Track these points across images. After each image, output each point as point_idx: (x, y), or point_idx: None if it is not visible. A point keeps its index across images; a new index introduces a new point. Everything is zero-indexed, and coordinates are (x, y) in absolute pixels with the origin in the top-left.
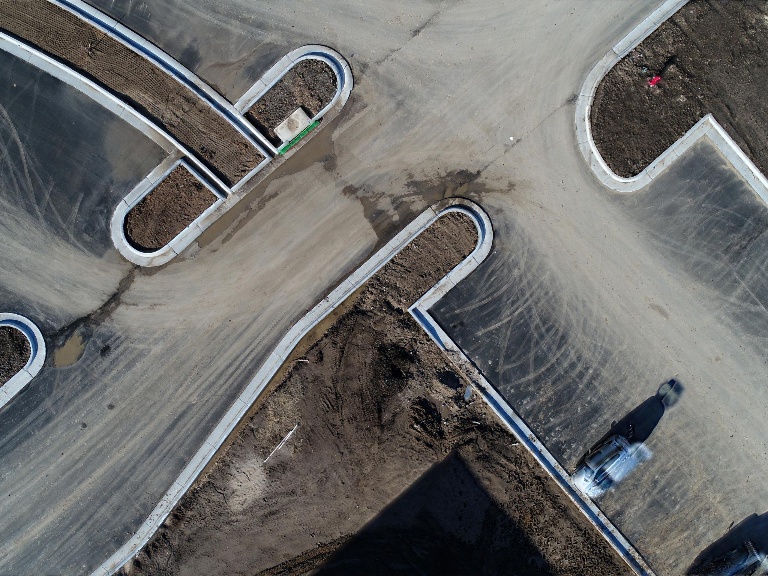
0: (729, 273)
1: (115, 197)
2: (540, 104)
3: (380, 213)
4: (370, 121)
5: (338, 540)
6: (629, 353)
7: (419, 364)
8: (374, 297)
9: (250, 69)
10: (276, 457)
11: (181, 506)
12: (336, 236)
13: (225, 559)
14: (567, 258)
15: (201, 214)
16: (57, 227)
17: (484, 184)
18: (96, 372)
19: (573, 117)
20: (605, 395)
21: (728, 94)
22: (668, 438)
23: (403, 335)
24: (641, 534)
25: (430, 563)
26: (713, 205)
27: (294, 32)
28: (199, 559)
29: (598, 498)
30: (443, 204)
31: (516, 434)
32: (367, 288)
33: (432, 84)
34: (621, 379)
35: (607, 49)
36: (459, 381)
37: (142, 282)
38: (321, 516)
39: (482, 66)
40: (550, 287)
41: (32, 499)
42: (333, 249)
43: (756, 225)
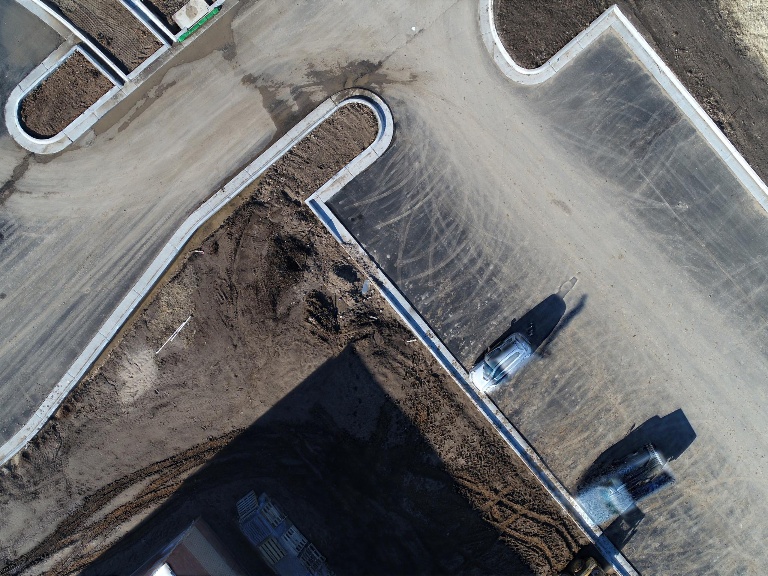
0: (633, 169)
1: (10, 82)
2: None
3: (279, 103)
4: (270, 9)
5: (230, 434)
6: (530, 250)
7: (316, 257)
8: (271, 188)
9: None
10: (168, 349)
11: (72, 397)
12: (234, 126)
13: (115, 451)
14: (469, 152)
15: (96, 101)
16: None
17: (385, 75)
18: None
19: (476, 7)
20: (505, 292)
21: None
22: (569, 337)
23: (300, 227)
24: (540, 434)
25: (324, 459)
26: (618, 99)
27: None
28: (89, 451)
29: (497, 397)
30: (343, 95)
31: (413, 329)
32: (264, 179)
33: None
34: (522, 276)
35: None
36: (357, 275)
37: (36, 169)
38: (213, 409)
39: None
40: (451, 181)
41: None
42: (231, 139)
43: (661, 120)
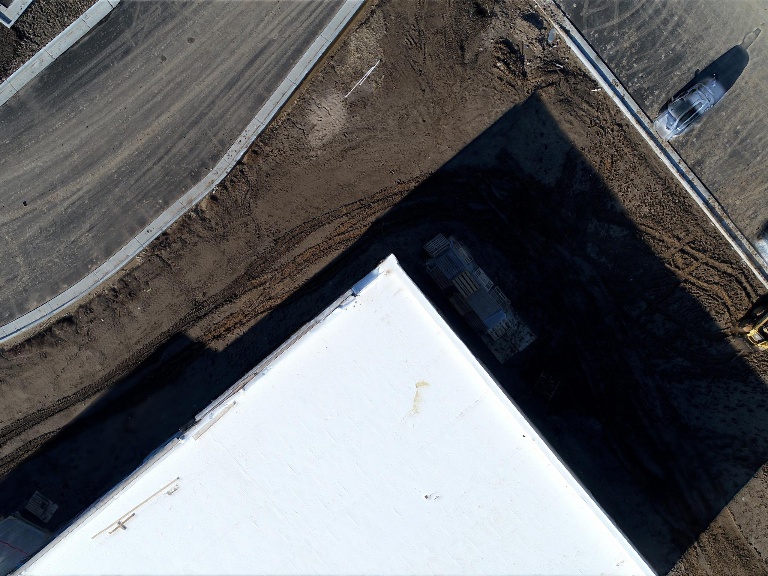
0: None
1: None
2: None
3: None
4: None
5: (418, 178)
6: (715, 0)
7: (503, 5)
8: None
9: None
10: (357, 93)
11: (260, 142)
12: None
13: (303, 194)
14: None
15: None
16: None
17: None
18: (177, 5)
19: None
20: (690, 43)
21: None
22: (752, 88)
23: None
24: (721, 184)
25: (509, 205)
26: None
27: None
28: (277, 194)
29: (679, 146)
30: None
31: (599, 77)
32: None
33: None
34: (706, 27)
35: None
36: (543, 24)
37: None
38: (401, 153)
39: None
40: None
41: (110, 132)
42: None
43: None
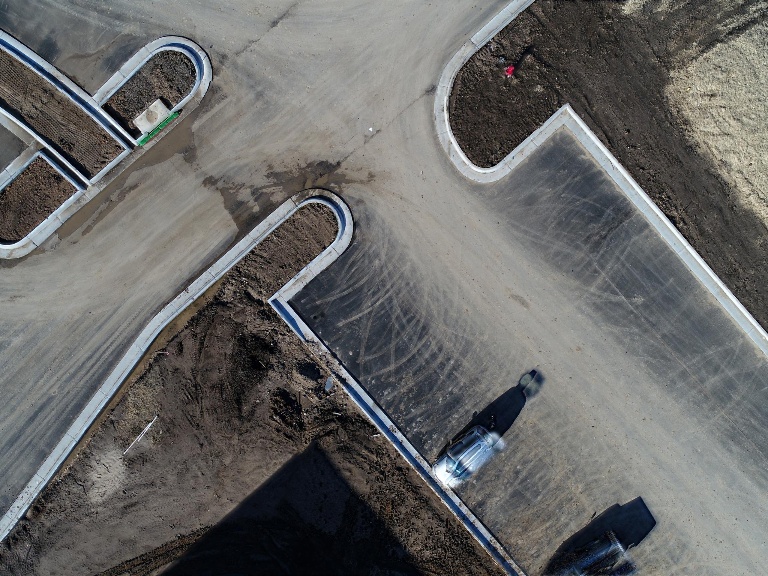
0: (589, 263)
1: None
2: (399, 95)
3: (240, 204)
4: (230, 112)
5: (198, 532)
6: (490, 344)
7: (280, 355)
8: (234, 288)
9: (109, 61)
10: (136, 449)
11: (42, 498)
12: (196, 227)
13: (85, 551)
14: (427, 249)
15: (60, 206)
16: None
17: (344, 175)
18: None
19: (432, 108)
20: (466, 386)
21: (585, 84)
22: (530, 429)
23: (264, 326)
24: (503, 525)
25: (290, 554)
26: (573, 195)
27: (152, 23)
28: (59, 551)
29: (460, 489)
30: (303, 195)
31: (376, 425)
32: (227, 279)
33: (291, 75)
34: (482, 370)
35: (465, 39)
36: (320, 372)
37: (2, 274)
38: (181, 508)
39: (341, 57)
40: (411, 278)
41: None
42: (193, 240)
43: (615, 215)
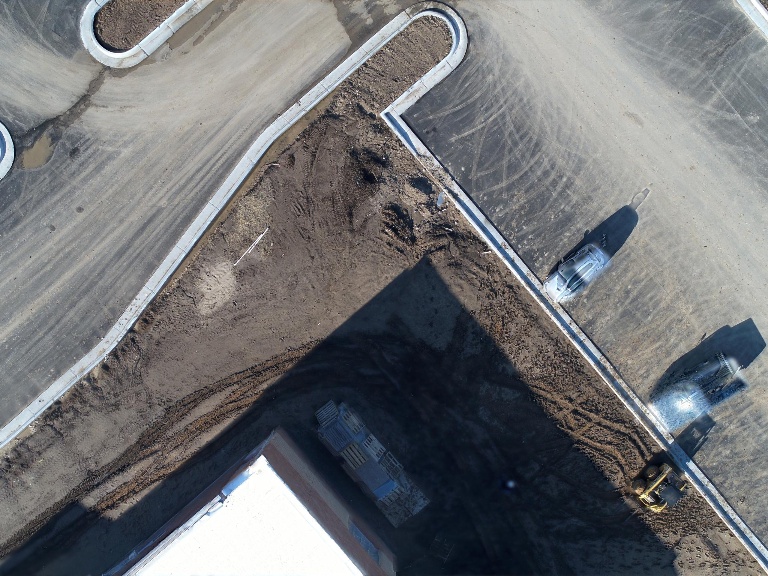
0: (705, 80)
1: None
2: None
3: (354, 16)
4: None
5: (308, 345)
6: (603, 161)
7: (391, 170)
8: (347, 101)
9: None
10: (246, 261)
11: (150, 310)
12: (309, 39)
13: (194, 362)
14: (542, 64)
15: (172, 14)
16: (26, 26)
17: None
18: (65, 174)
19: None
20: (579, 204)
21: None
22: (641, 248)
23: (376, 140)
24: (613, 344)
25: (400, 369)
26: (690, 11)
27: None
28: (168, 363)
29: (570, 307)
30: (417, 8)
31: (488, 240)
32: (340, 92)
33: None
34: (595, 188)
35: None
36: (432, 187)
37: (112, 84)
38: (291, 320)
39: None
40: (525, 94)
41: None
42: (306, 52)
43: (733, 32)
